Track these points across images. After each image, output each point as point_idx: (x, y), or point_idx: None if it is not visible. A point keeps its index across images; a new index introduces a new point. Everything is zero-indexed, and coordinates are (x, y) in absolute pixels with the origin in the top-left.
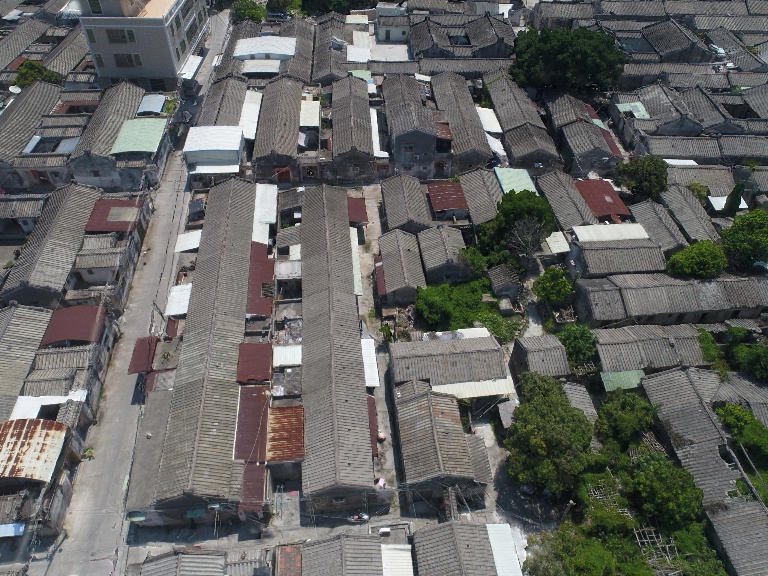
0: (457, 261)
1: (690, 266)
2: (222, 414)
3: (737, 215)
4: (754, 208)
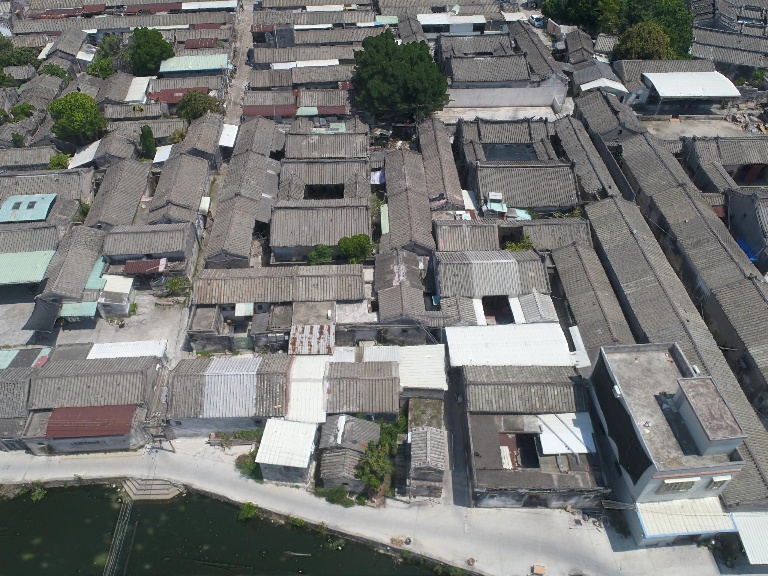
0: None
1: None
2: (67, 3)
3: (149, 159)
4: None
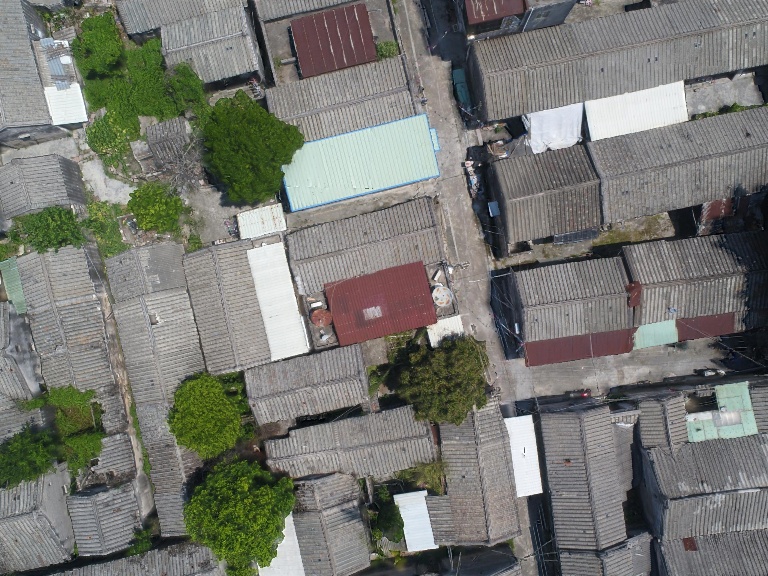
0: (171, 64)
1: (177, 397)
2: None
3: None
4: (435, 569)
